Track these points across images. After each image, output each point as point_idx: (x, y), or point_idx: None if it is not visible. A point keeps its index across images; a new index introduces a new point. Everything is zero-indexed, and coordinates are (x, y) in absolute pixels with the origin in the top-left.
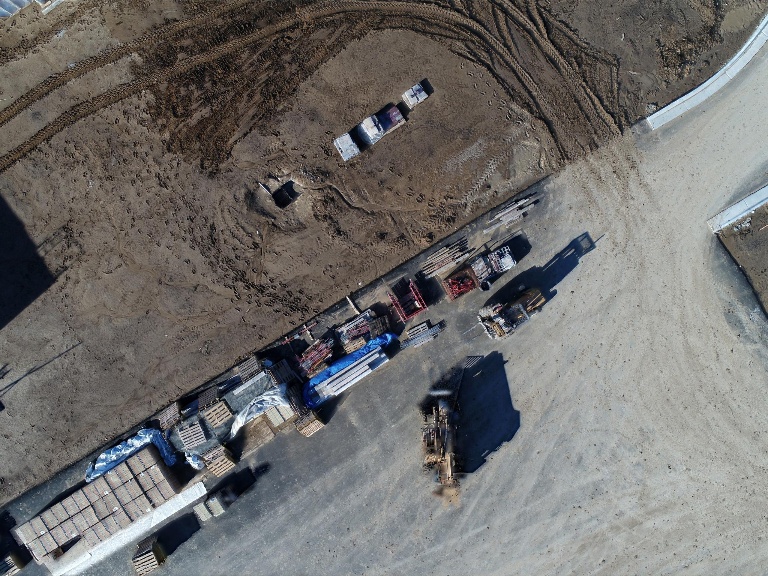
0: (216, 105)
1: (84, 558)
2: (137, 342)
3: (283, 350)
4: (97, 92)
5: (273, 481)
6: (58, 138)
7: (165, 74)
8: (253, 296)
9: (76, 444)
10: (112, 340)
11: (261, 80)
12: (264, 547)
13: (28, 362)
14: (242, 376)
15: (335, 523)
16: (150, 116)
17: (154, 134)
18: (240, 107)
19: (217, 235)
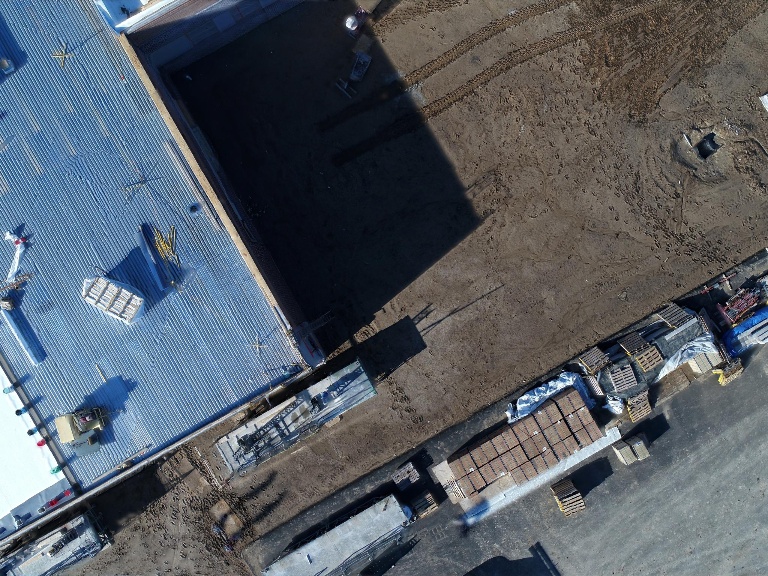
0: (647, 56)
1: (498, 499)
2: (558, 286)
3: (701, 299)
4: (534, 39)
5: (686, 429)
6: (494, 83)
7: (600, 24)
8: (673, 245)
9: (494, 385)
10: (534, 283)
11: (692, 33)
12: (675, 494)
13: (452, 302)
14: (671, 322)
15: (745, 473)
16: (583, 64)
17: (586, 82)
18: (670, 59)
19: (641, 183)
